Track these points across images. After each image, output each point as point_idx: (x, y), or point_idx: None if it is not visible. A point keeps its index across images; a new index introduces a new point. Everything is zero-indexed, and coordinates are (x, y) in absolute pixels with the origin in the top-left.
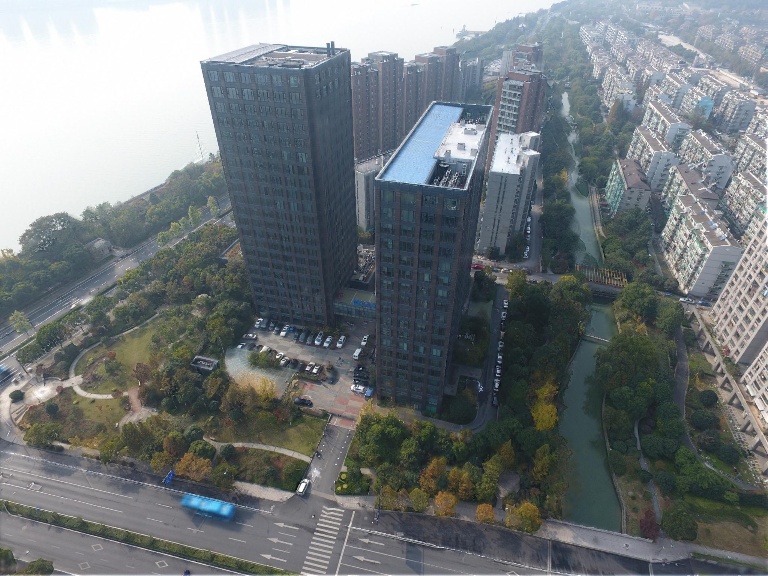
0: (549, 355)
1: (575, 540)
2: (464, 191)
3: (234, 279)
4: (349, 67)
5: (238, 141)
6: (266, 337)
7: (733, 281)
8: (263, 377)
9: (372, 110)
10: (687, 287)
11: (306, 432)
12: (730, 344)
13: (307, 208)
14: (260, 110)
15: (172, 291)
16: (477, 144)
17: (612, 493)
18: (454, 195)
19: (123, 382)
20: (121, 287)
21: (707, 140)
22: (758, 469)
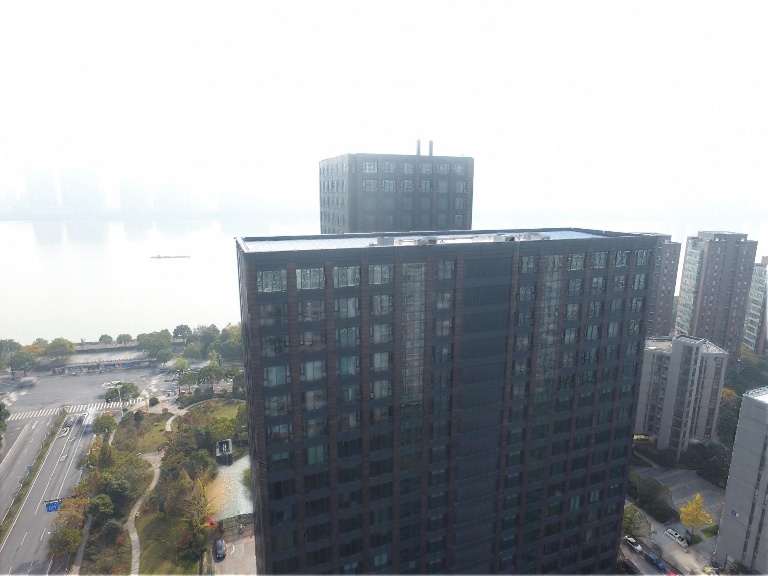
0: None
1: None
2: (243, 253)
3: None
4: (466, 176)
5: None
6: None
7: None
8: None
9: (662, 293)
10: None
11: None
12: None
13: None
14: None
15: None
16: None
17: None
18: None
19: None
20: None
21: None
22: None
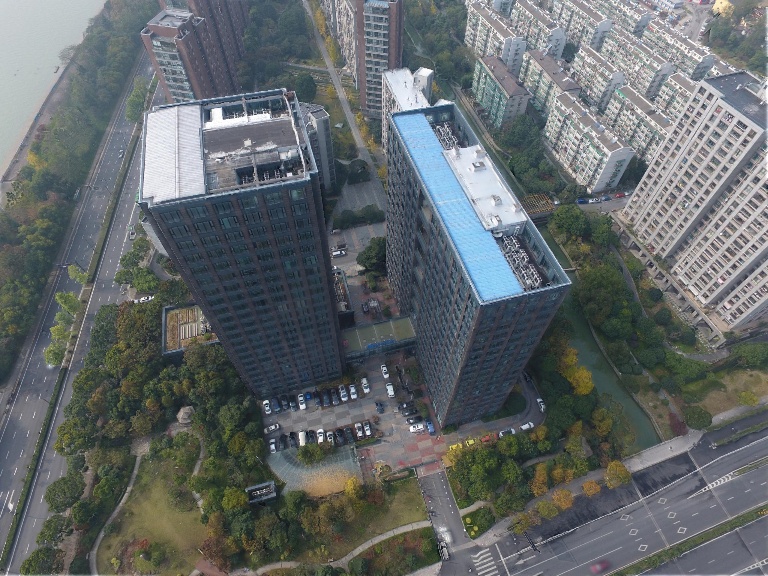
0: (561, 324)
1: (643, 465)
2: None
3: (211, 376)
4: None
5: (218, 271)
6: (288, 419)
7: (643, 187)
8: (350, 482)
9: (213, 71)
10: (589, 187)
11: (407, 499)
12: (654, 243)
13: (318, 300)
14: (249, 233)
15: (144, 426)
16: (502, 187)
17: (636, 408)
18: (559, 290)
19: (181, 562)
20: (67, 453)
21: (537, 10)
22: (705, 339)
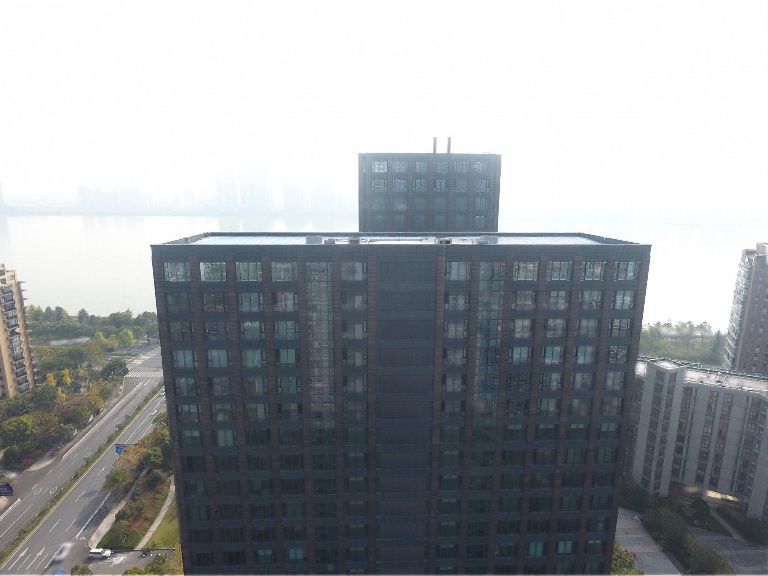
0: None
1: None
2: None
3: None
4: (489, 175)
5: None
6: None
7: None
8: None
9: None
10: None
11: None
12: None
13: None
14: None
15: None
16: None
17: None
18: None
19: None
20: None
21: None
22: None
